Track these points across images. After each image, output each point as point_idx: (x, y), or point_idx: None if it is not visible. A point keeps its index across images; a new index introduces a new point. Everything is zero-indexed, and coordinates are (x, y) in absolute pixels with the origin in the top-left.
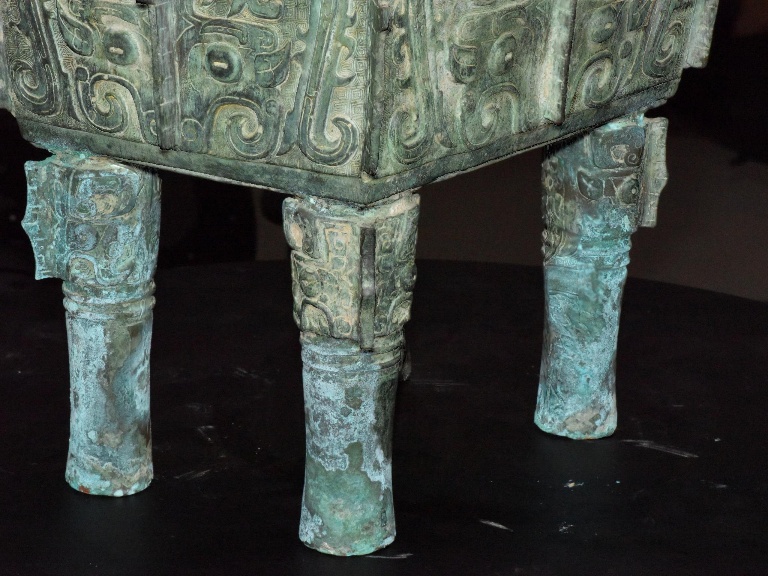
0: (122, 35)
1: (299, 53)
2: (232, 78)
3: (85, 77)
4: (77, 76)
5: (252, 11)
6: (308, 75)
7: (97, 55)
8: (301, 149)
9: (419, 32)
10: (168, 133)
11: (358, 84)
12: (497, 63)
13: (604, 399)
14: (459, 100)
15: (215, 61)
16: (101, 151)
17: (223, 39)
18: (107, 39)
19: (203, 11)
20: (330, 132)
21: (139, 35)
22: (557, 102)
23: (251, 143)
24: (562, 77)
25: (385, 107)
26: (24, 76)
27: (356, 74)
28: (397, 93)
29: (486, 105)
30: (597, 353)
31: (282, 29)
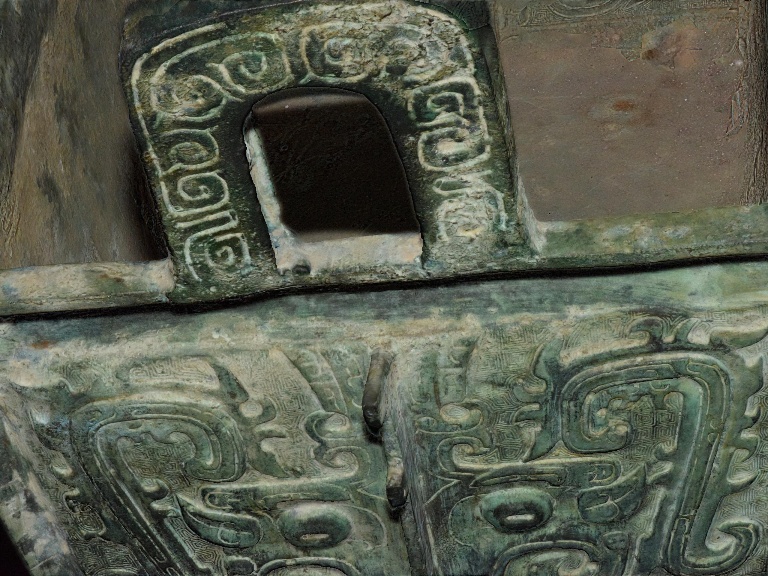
0: (322, 518)
1: (662, 475)
2: (539, 525)
3: (250, 570)
4: (234, 572)
5: (575, 450)
6: (679, 495)
7: (267, 541)
8: (671, 573)
9: None
10: None
11: (763, 481)
12: None
13: None
14: None
15: None
16: None
17: (515, 485)
18: (295, 528)
19: (473, 461)
20: (714, 540)
21: (350, 508)
22: None
23: None
24: None
25: None
26: None
27: (759, 472)
28: None
29: None
30: None
31: (628, 455)
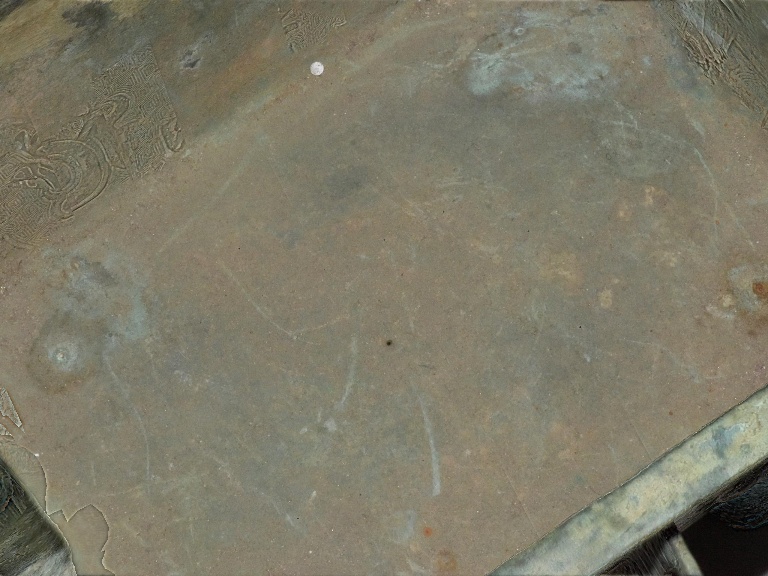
0: None
1: None
2: None
3: None
4: None
5: None
6: None
7: None
8: None
9: None
10: None
11: None
12: None
13: (765, 505)
14: None
15: None
16: None
17: None
18: None
19: None
20: None
21: None
22: None
23: None
24: None
25: None
26: None
27: None
28: None
29: None
30: (759, 487)
31: None
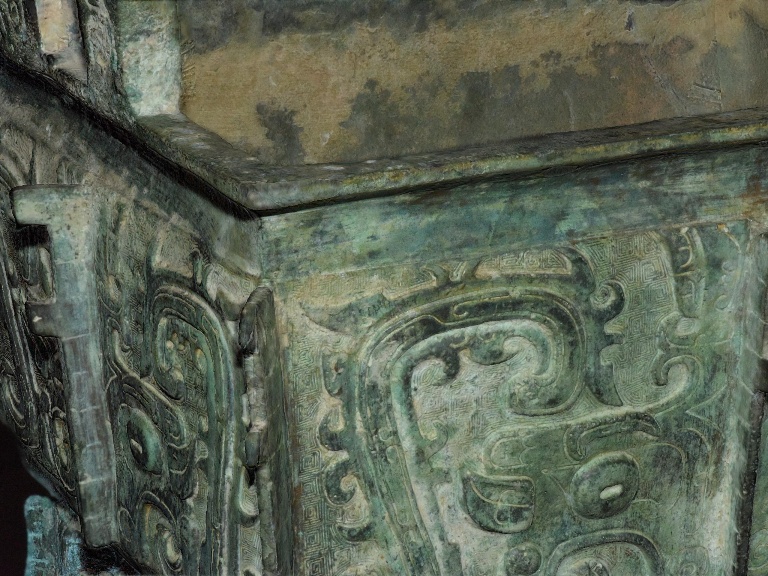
0: None
1: (202, 459)
2: (150, 468)
3: (46, 407)
4: (41, 403)
5: (155, 379)
6: None
7: None
8: None
9: (382, 457)
10: (96, 524)
11: None
12: (583, 502)
13: None
14: (502, 556)
15: (131, 438)
16: (77, 513)
17: (141, 407)
18: (51, 364)
19: (124, 358)
20: None
21: None
22: (732, 562)
23: (174, 570)
24: (738, 525)
25: (314, 569)
26: (11, 382)
27: None
28: (343, 547)
29: (573, 562)
30: None
31: (186, 416)
